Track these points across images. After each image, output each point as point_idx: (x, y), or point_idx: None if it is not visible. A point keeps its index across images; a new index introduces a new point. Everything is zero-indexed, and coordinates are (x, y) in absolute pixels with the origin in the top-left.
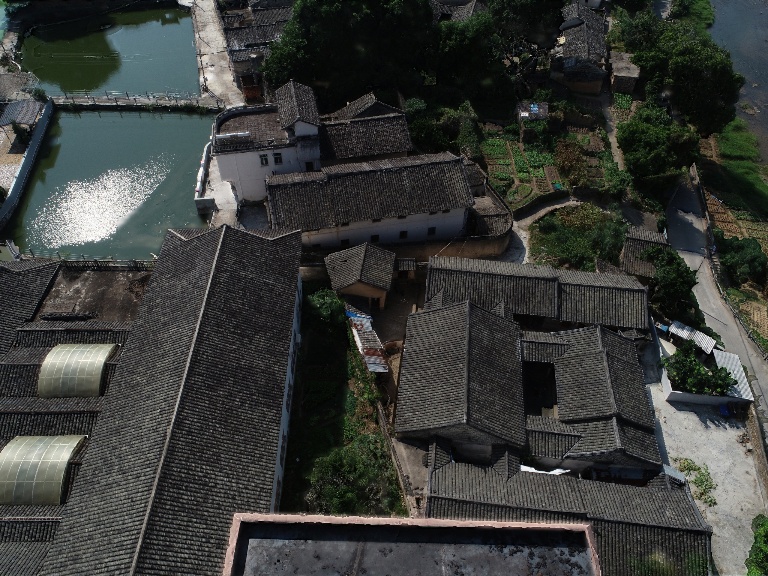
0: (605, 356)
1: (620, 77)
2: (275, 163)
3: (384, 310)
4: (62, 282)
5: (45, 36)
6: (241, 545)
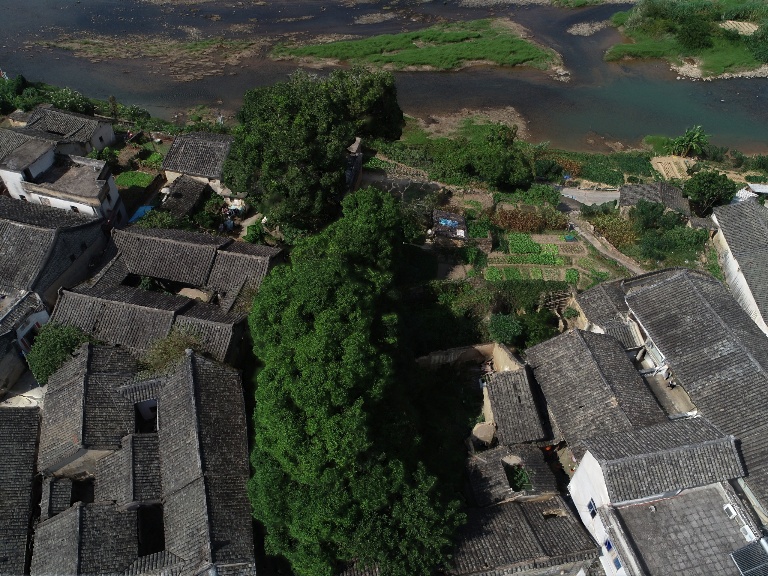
0: None
1: (356, 150)
2: None
3: None
4: None
5: None
6: None
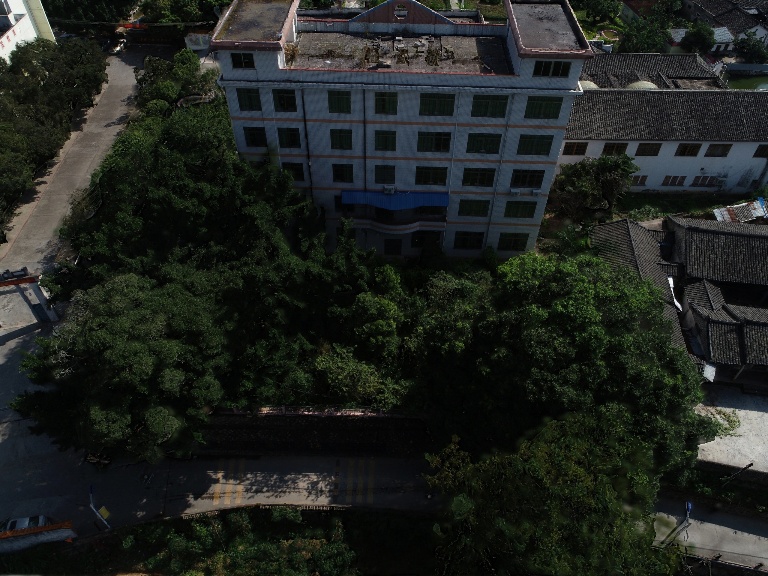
0: None
1: None
2: None
3: None
4: (703, 82)
5: None
6: (558, 3)
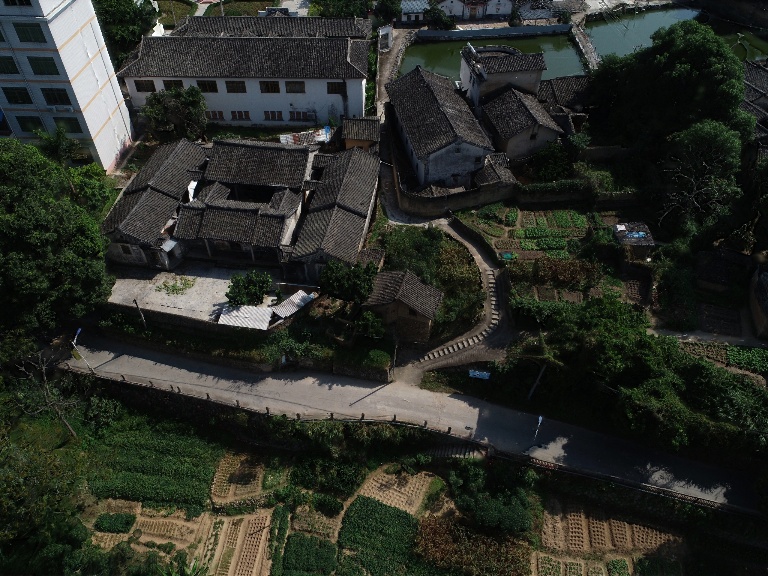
0: None
1: None
2: (473, 85)
3: None
4: None
5: (706, 23)
6: None
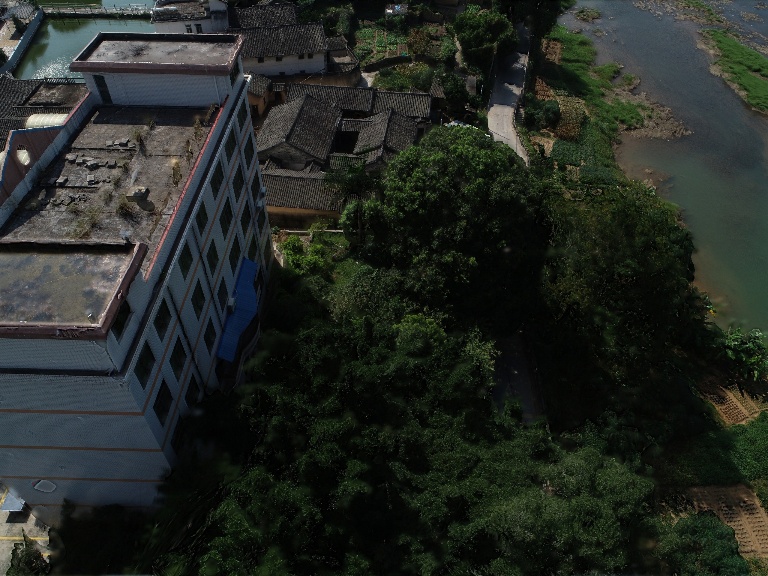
0: (387, 120)
1: None
2: (197, 32)
3: (263, 117)
4: (43, 90)
5: None
6: (100, 41)
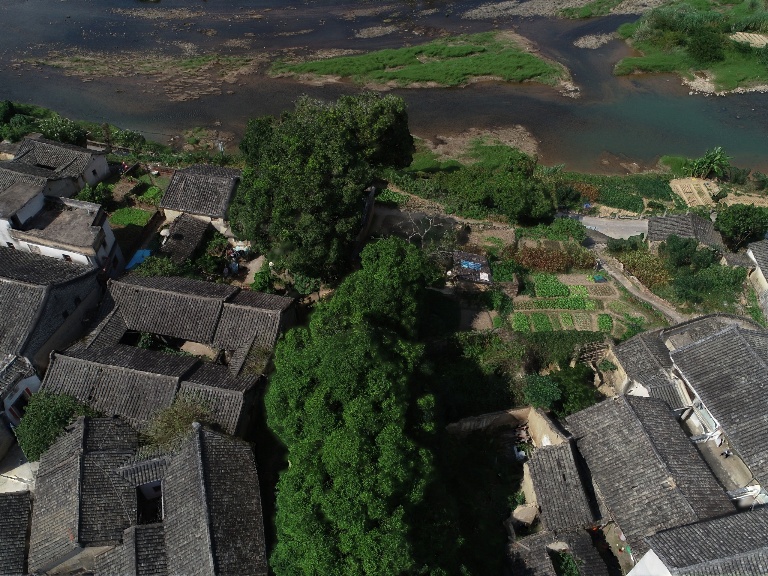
0: None
1: None
2: None
3: None
4: None
5: None
6: None
